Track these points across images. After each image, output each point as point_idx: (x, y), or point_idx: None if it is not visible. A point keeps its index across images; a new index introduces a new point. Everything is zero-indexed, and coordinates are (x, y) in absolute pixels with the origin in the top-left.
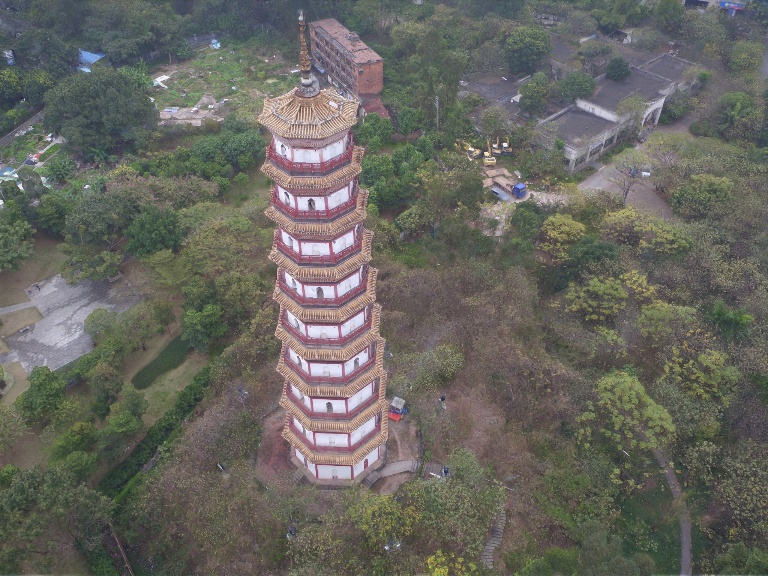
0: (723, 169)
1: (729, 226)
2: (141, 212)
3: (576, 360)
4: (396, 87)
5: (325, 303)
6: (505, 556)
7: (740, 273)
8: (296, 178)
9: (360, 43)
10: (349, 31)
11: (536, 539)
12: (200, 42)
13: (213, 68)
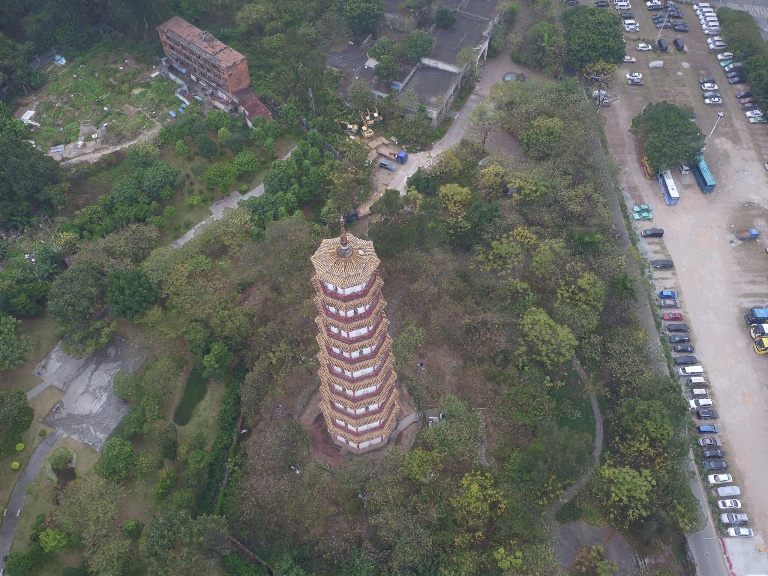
0: (551, 107)
1: (568, 161)
2: (105, 275)
3: (498, 305)
4: (260, 74)
5: (366, 358)
6: (493, 454)
7: (583, 196)
8: (347, 303)
9: (217, 42)
10: (200, 29)
11: (507, 435)
12: (43, 61)
13: (72, 90)
